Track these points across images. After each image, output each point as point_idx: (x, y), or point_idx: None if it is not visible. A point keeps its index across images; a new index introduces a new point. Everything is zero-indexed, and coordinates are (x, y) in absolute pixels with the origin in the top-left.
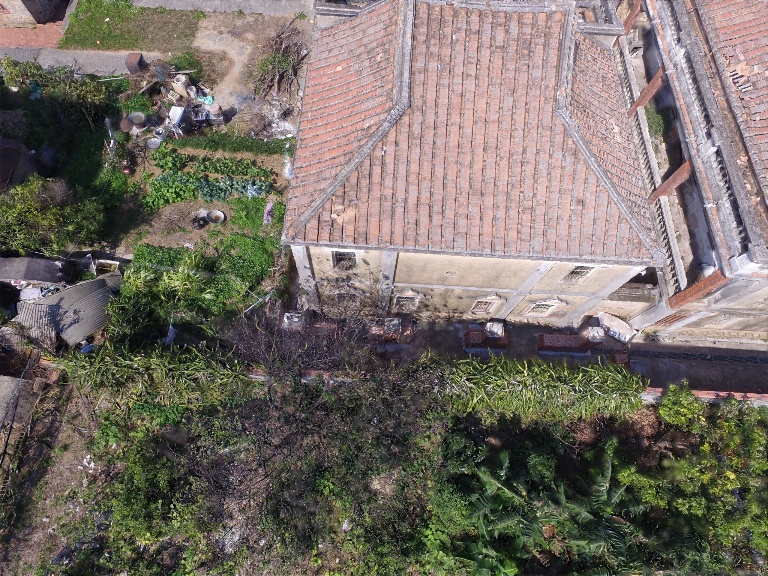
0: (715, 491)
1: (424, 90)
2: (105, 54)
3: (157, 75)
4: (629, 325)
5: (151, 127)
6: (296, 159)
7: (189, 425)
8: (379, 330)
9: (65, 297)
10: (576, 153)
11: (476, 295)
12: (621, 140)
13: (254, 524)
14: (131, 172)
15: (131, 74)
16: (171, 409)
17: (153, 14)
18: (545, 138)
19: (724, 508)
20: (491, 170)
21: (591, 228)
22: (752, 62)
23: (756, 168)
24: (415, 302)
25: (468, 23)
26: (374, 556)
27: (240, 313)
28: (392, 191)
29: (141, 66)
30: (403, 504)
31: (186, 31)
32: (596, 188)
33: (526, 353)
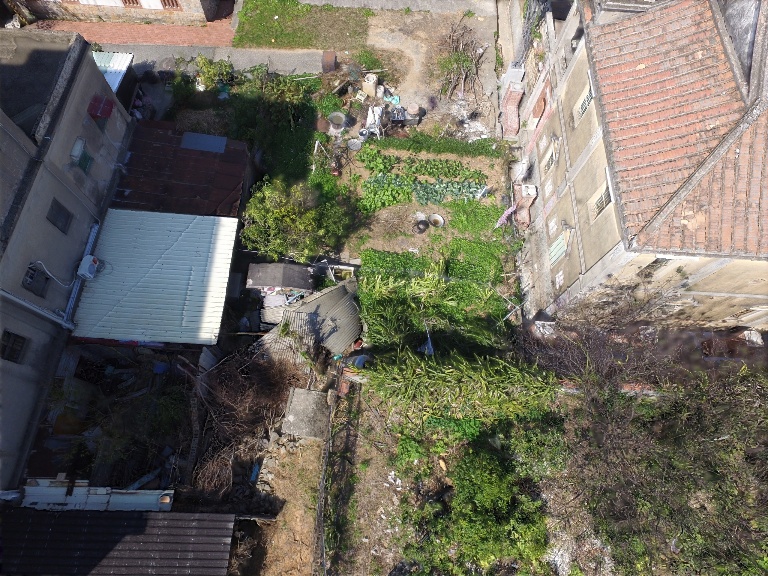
0: None
1: None
2: (281, 53)
3: (351, 74)
4: None
5: (346, 128)
6: (617, 162)
7: (507, 441)
8: (621, 338)
9: (321, 305)
10: None
11: (753, 303)
12: None
13: (579, 545)
14: (338, 174)
15: (324, 73)
16: (468, 423)
17: (321, 12)
18: None
19: None
20: None
21: None
22: None
23: None
24: (672, 310)
25: None
26: None
27: (499, 321)
28: (746, 196)
29: (334, 65)
30: (727, 524)
31: (357, 29)
32: None
33: (767, 362)
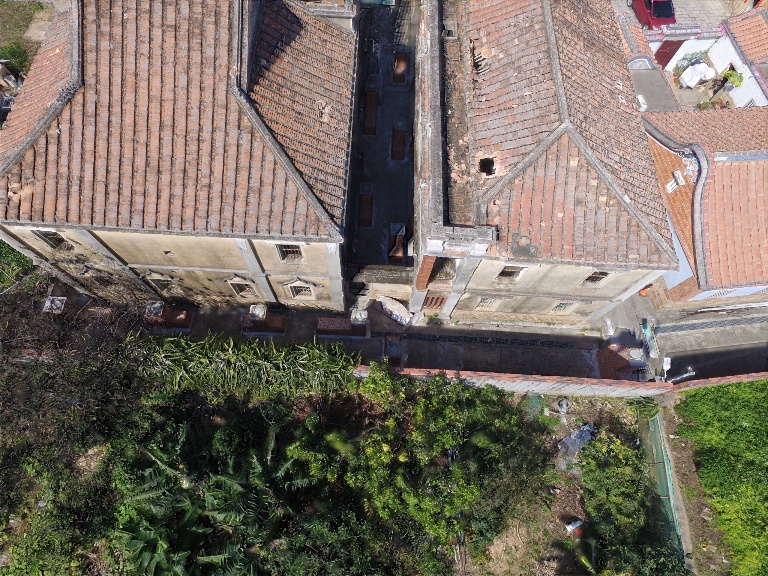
0: (371, 463)
1: (98, 69)
2: None
3: None
4: (406, 308)
5: None
6: None
7: None
8: None
9: None
10: (253, 131)
11: (221, 277)
12: (328, 120)
13: None
14: None
15: None
16: None
17: None
18: (220, 116)
19: (377, 480)
20: (167, 148)
21: (268, 205)
22: (491, 45)
23: (469, 148)
24: None
25: (139, 2)
26: (37, 529)
27: None
28: (68, 169)
29: None
30: (105, 480)
31: (20, 22)
32: (274, 166)
33: (305, 336)
